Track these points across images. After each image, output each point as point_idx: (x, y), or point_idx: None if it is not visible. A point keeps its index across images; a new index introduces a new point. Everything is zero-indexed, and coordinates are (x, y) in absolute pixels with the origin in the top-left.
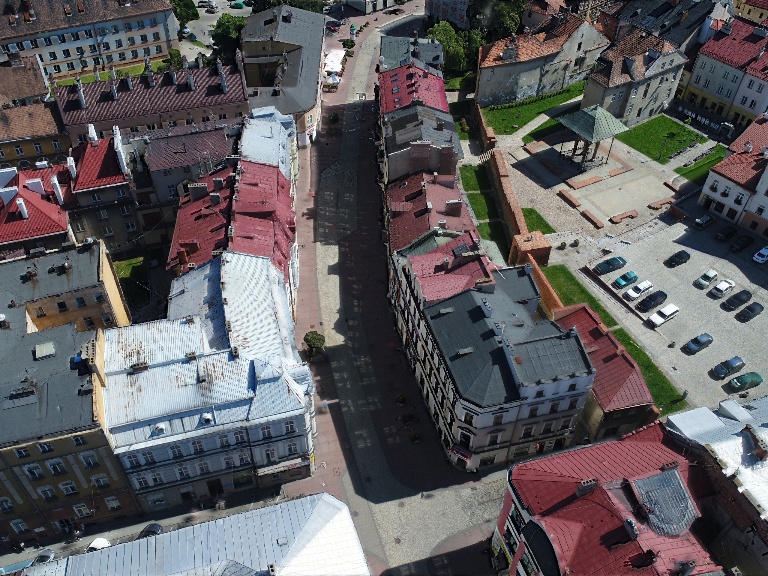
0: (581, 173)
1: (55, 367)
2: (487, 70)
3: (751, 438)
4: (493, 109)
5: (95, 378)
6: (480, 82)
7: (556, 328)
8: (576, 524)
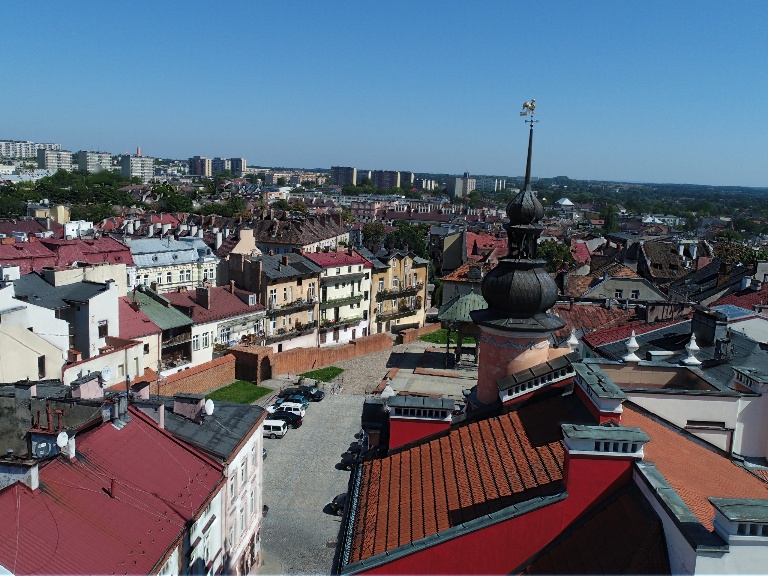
0: (444, 368)
1: None
2: (450, 285)
3: None
4: (454, 331)
5: None
6: (443, 297)
7: None
8: None
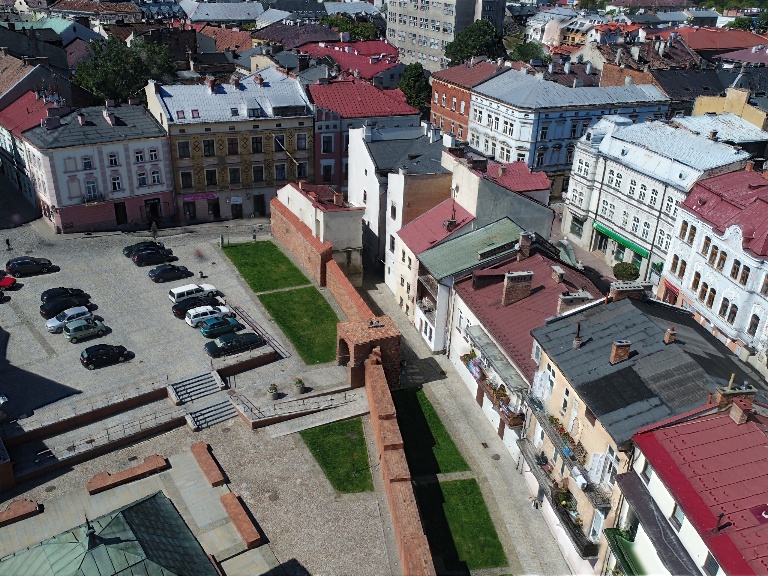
0: None
1: (761, 101)
2: None
3: (262, 81)
4: None
5: (725, 98)
6: None
7: (376, 159)
8: (384, 91)
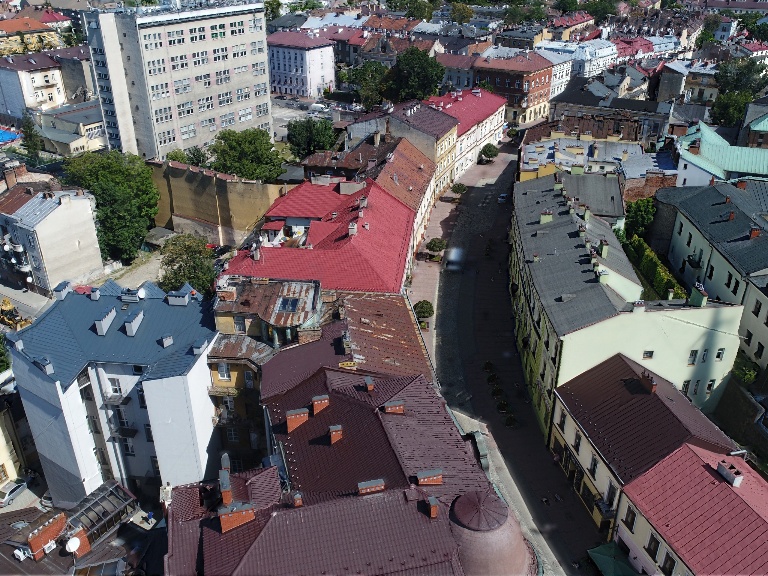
0: None
1: None
2: None
3: None
4: None
5: None
6: None
7: None
8: None
